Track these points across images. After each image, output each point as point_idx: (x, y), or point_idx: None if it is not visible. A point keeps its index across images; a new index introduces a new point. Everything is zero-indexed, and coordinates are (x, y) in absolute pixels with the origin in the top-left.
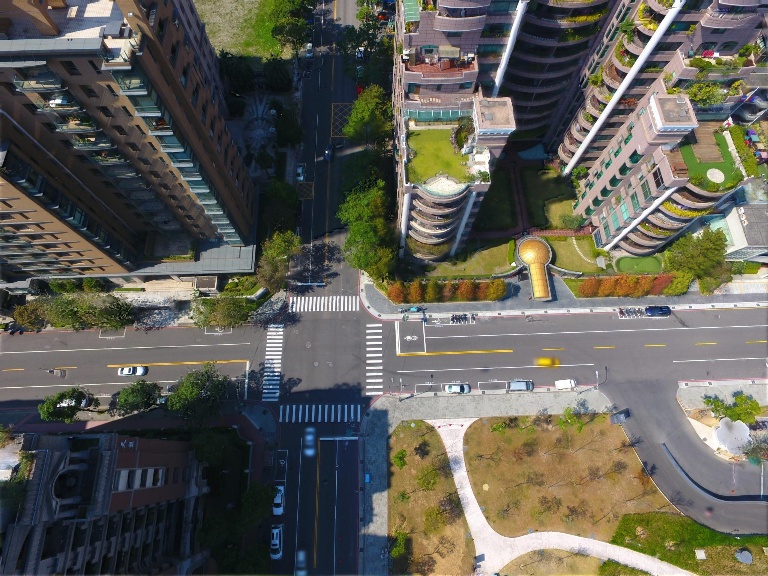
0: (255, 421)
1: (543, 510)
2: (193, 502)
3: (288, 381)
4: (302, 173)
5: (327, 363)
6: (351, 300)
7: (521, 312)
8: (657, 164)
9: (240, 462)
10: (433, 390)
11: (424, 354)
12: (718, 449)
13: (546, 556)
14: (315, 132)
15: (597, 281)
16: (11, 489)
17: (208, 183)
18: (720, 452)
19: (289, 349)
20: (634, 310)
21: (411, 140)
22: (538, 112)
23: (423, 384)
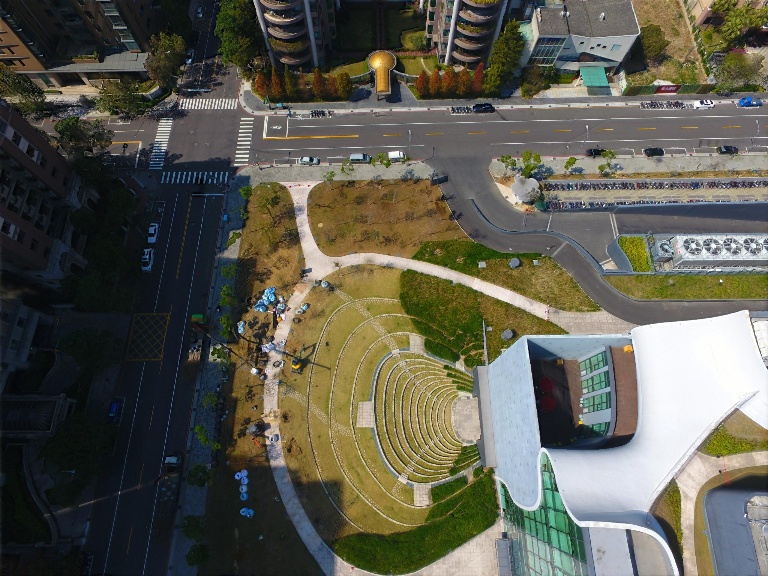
0: (141, 182)
1: (363, 239)
2: None
3: (172, 156)
4: (201, 11)
5: (205, 144)
6: (231, 101)
7: (370, 110)
8: None
9: None
10: (289, 163)
11: (285, 138)
12: (516, 203)
13: (361, 269)
14: None
15: (424, 73)
16: None
17: None
18: (517, 205)
19: (175, 134)
20: (464, 108)
21: None
22: None
23: (282, 158)
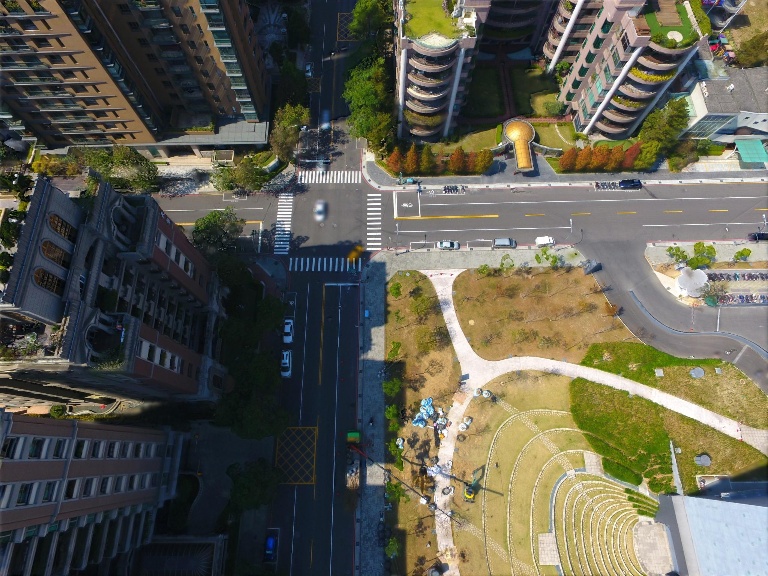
0: (267, 270)
1: (522, 340)
2: (214, 319)
3: (297, 238)
4: (310, 70)
5: (332, 224)
6: (354, 174)
7: (507, 185)
8: (624, 29)
9: (254, 299)
10: (426, 247)
11: (419, 218)
12: (680, 296)
13: (523, 375)
14: (322, 37)
15: (574, 150)
16: (81, 201)
17: (230, 38)
18: (682, 298)
19: (298, 213)
20: (609, 184)
21: (408, 6)
22: (524, 8)
23: (417, 242)
